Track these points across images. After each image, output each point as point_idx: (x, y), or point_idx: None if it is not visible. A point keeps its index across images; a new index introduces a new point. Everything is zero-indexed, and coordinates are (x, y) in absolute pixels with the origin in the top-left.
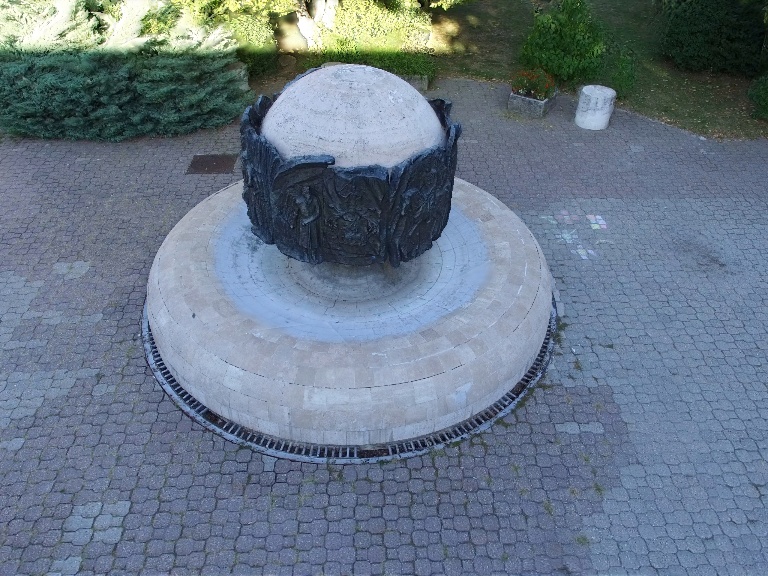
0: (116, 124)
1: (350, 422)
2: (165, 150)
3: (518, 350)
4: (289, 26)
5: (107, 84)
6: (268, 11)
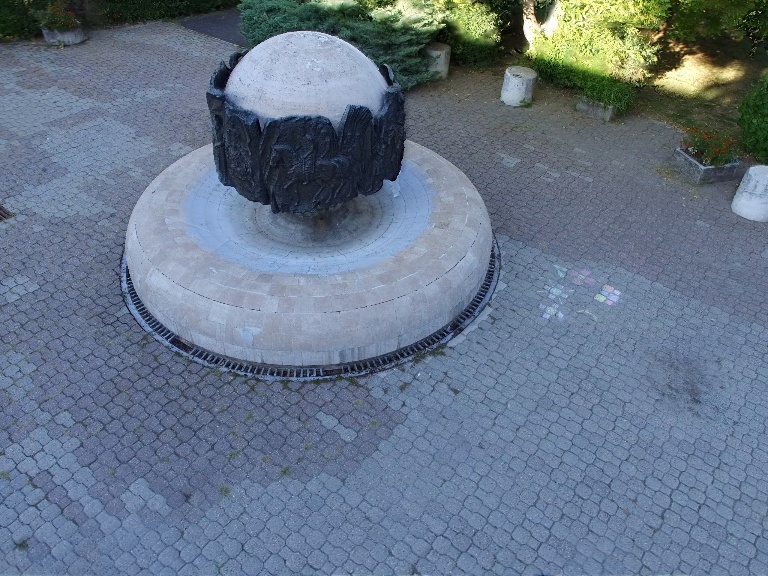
0: None
1: (165, 307)
2: None
3: (327, 330)
4: (517, 26)
5: None
6: None
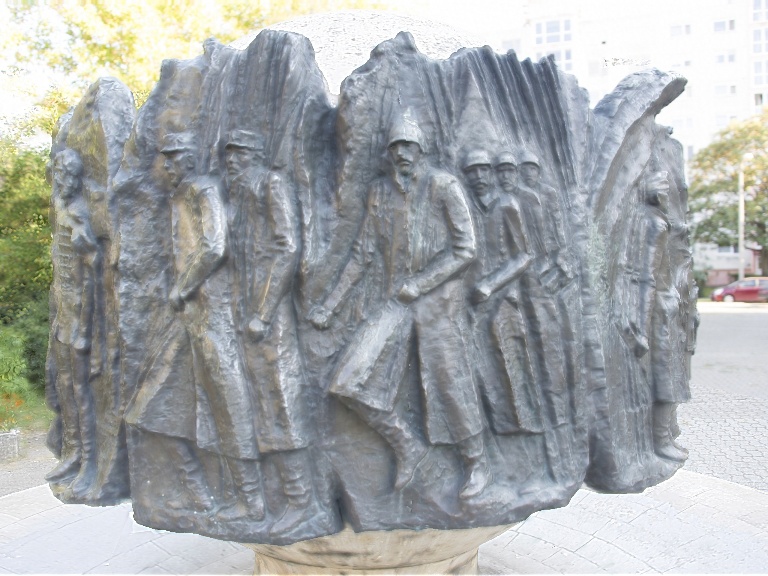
0: None
1: None
2: None
3: None
4: None
5: None
6: None
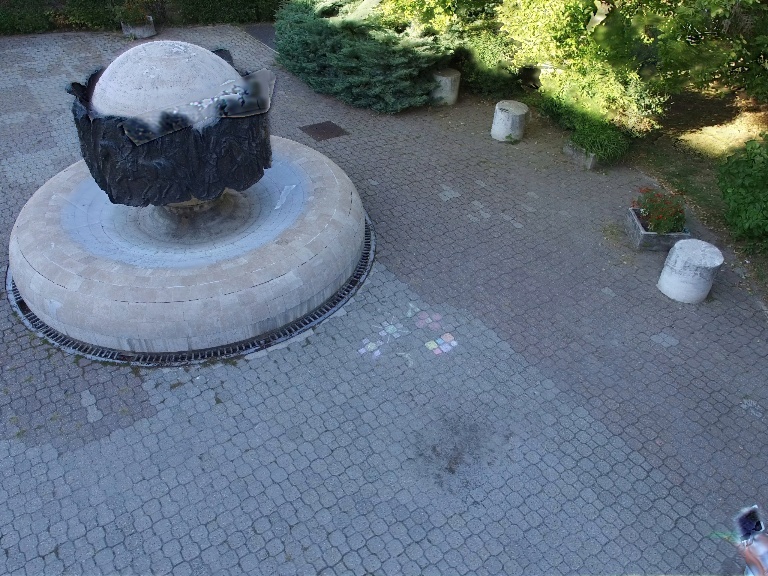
0: (315, 78)
1: None
2: (325, 110)
3: (115, 317)
4: None
5: (316, 45)
6: (430, 26)
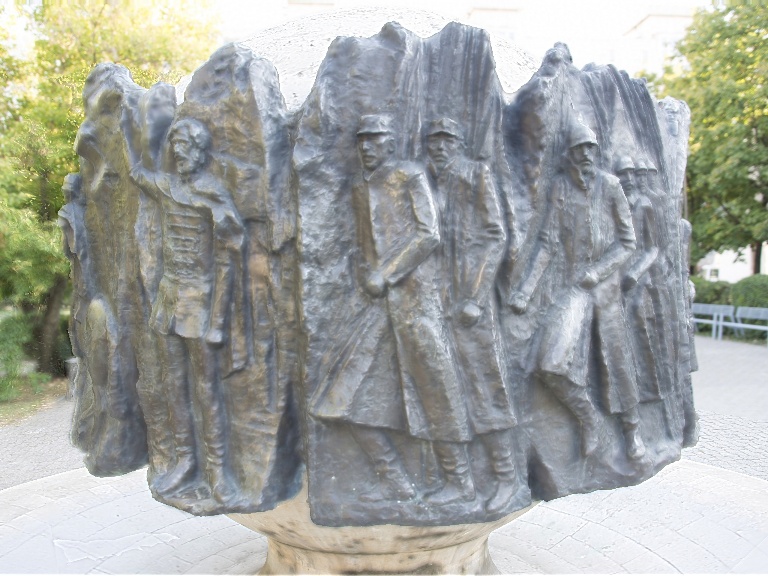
0: None
1: None
2: None
3: None
4: None
5: None
6: None
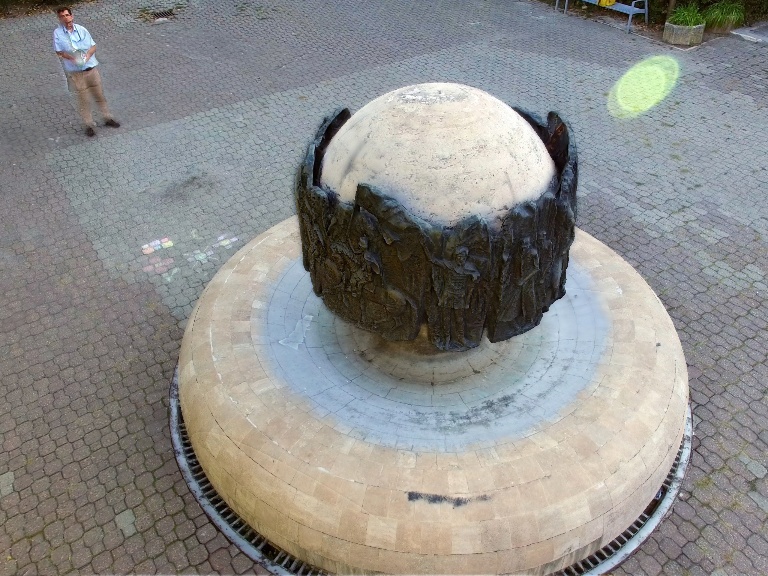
0: None
1: None
2: None
3: None
4: None
5: None
6: None
